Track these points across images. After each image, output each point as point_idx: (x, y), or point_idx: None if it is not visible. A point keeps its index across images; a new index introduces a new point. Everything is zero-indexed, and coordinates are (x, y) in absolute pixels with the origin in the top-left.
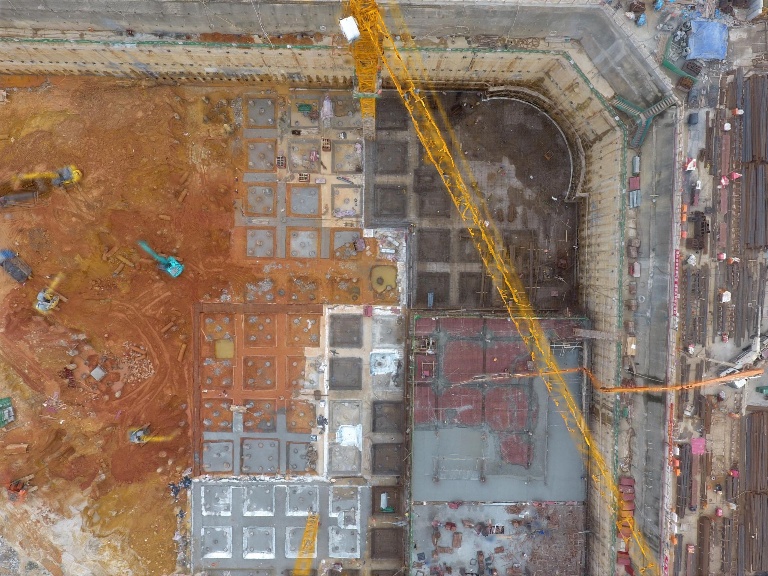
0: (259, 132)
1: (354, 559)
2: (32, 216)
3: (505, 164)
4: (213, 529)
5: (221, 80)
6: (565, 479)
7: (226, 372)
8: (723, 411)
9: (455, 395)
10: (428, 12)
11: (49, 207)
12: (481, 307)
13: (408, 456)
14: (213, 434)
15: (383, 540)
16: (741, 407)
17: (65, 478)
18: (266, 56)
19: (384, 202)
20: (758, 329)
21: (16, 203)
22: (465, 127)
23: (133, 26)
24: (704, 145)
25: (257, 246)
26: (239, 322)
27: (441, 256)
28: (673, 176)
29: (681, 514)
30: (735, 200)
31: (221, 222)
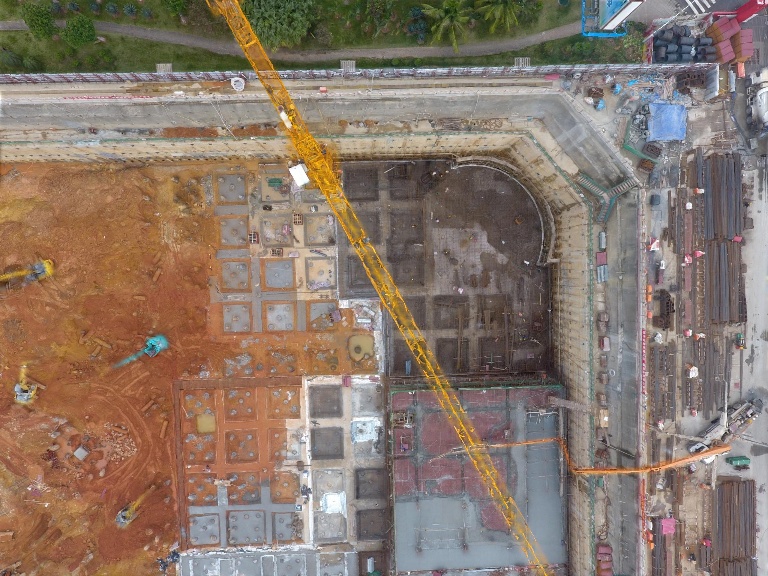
0: (230, 209)
1: None
2: (5, 307)
3: (477, 230)
4: None
5: (189, 160)
6: (546, 543)
7: (209, 446)
8: (694, 482)
9: (435, 466)
10: (388, 104)
11: (22, 297)
12: (458, 372)
13: None
14: (198, 508)
15: None
16: None
17: (53, 560)
18: (231, 145)
19: (358, 272)
20: (725, 404)
21: None
22: (435, 196)
23: (95, 125)
24: (667, 224)
25: (234, 321)
26: (219, 397)
27: (417, 324)
28: (637, 256)
29: None
30: (699, 277)
31: (196, 300)
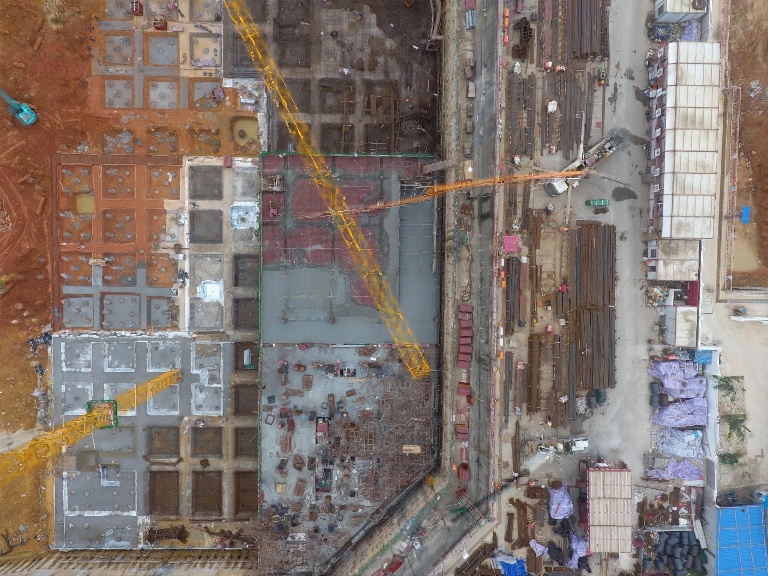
0: None
1: (217, 416)
2: None
3: (366, 13)
4: (74, 386)
5: None
6: (417, 321)
7: (86, 226)
8: (553, 226)
9: (304, 234)
10: None
11: None
12: None
13: (257, 297)
14: (72, 288)
15: (248, 398)
16: (570, 221)
17: None
18: None
19: (244, 52)
20: (581, 135)
21: None
22: None
23: None
24: None
25: (116, 97)
26: (97, 174)
27: (301, 106)
28: None
29: (509, 329)
30: (561, 8)
31: (77, 71)
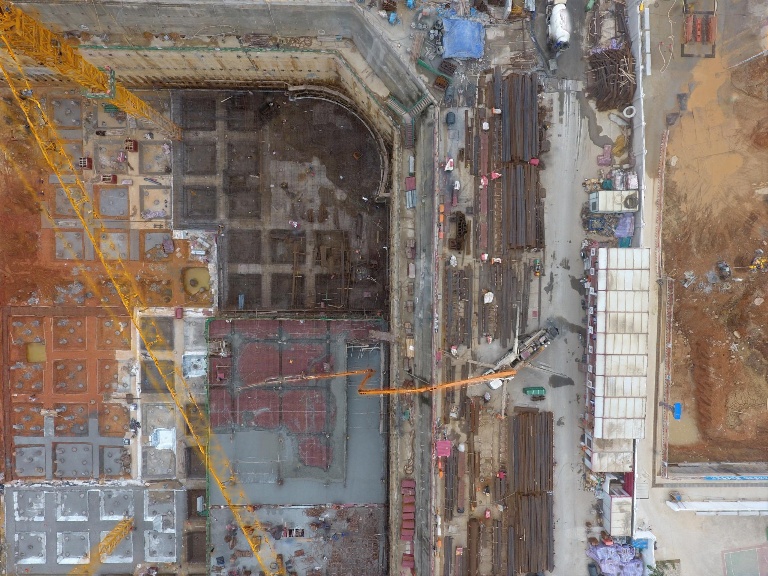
0: (64, 133)
1: (170, 563)
2: None
3: (315, 164)
4: (27, 534)
5: (20, 80)
6: (365, 481)
7: (38, 376)
8: (490, 412)
9: (251, 398)
10: (180, 11)
11: None
12: (293, 308)
13: None
14: (24, 439)
15: (201, 544)
16: (507, 408)
17: None
18: None
19: (194, 203)
20: (516, 330)
21: None
22: (273, 127)
23: None
24: (464, 145)
25: (66, 248)
26: (48, 325)
27: (252, 257)
28: (433, 176)
29: (448, 516)
30: (497, 200)
31: (27, 224)
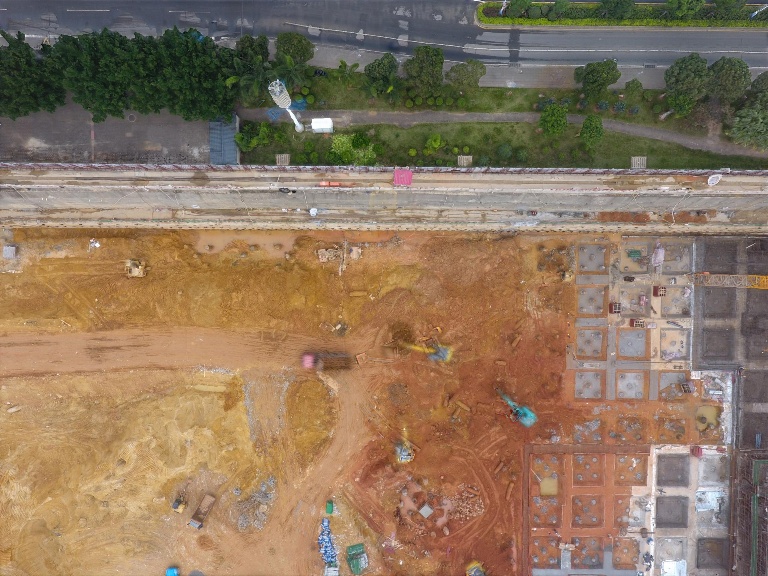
0: (591, 278)
1: None
2: (392, 371)
3: None
4: None
5: None
6: None
7: (552, 510)
8: None
9: None
10: None
11: (408, 362)
12: None
13: None
14: (542, 571)
15: None
16: None
17: None
18: None
19: (710, 344)
20: None
21: (377, 359)
22: None
23: None
24: None
25: (585, 388)
26: (568, 462)
27: None
28: None
29: None
30: None
31: (553, 366)
